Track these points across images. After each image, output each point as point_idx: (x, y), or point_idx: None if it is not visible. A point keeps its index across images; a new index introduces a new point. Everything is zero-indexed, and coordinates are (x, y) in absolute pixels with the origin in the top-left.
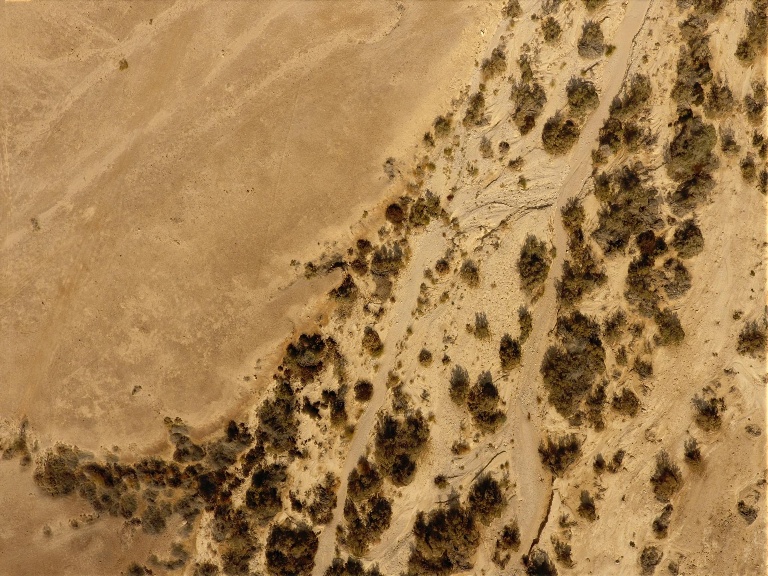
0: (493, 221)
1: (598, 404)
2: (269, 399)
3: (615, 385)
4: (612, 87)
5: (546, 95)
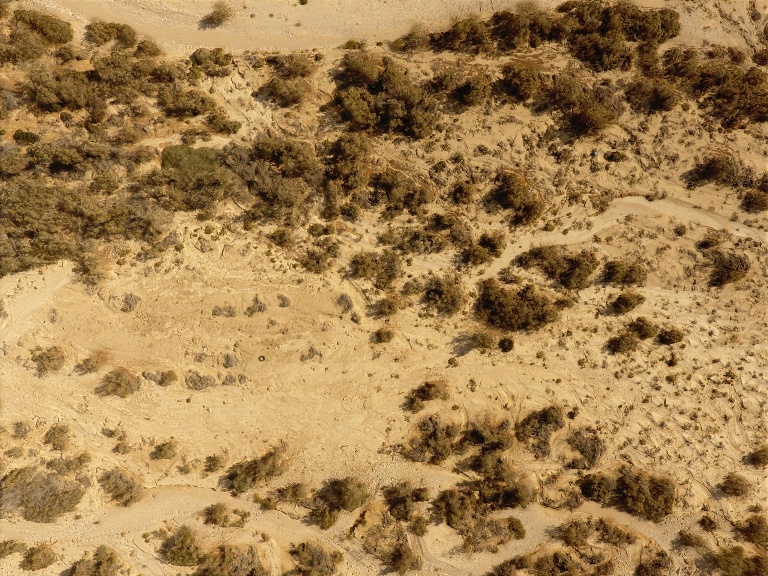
0: None
1: (58, 471)
2: None
3: (43, 452)
4: None
5: None
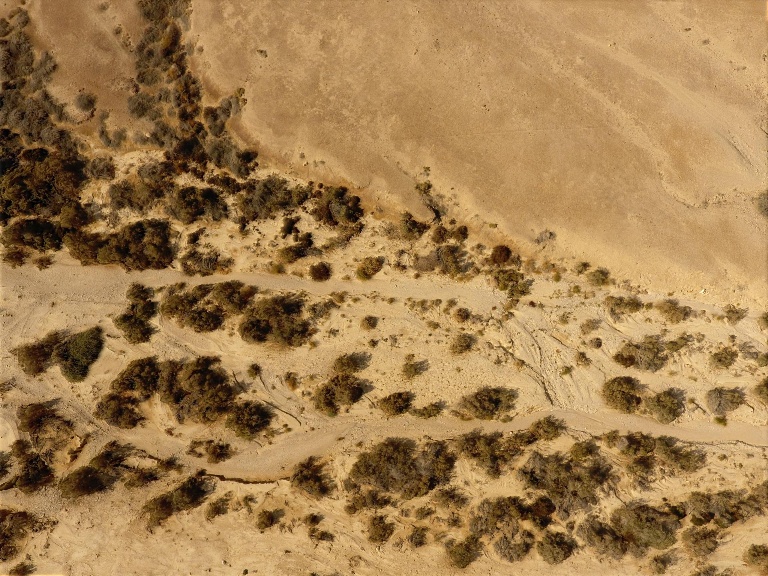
0: (521, 352)
1: (373, 502)
2: (288, 183)
3: (395, 514)
4: (686, 433)
5: (660, 370)
